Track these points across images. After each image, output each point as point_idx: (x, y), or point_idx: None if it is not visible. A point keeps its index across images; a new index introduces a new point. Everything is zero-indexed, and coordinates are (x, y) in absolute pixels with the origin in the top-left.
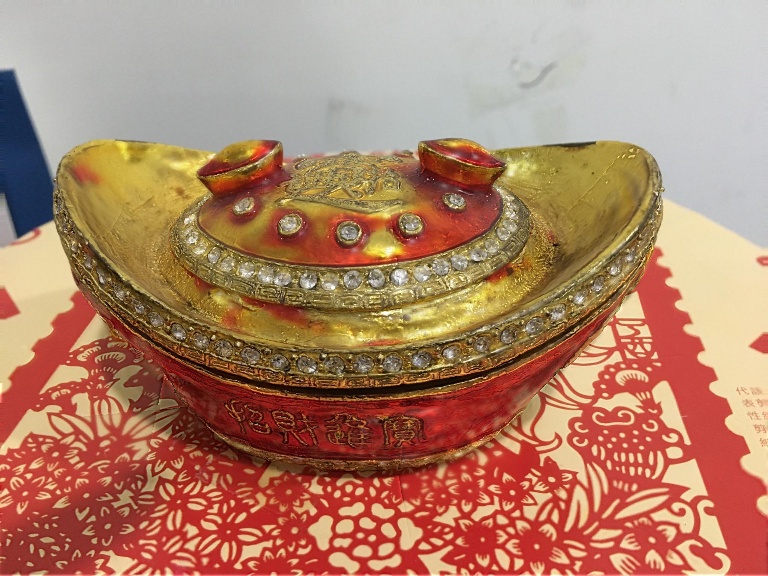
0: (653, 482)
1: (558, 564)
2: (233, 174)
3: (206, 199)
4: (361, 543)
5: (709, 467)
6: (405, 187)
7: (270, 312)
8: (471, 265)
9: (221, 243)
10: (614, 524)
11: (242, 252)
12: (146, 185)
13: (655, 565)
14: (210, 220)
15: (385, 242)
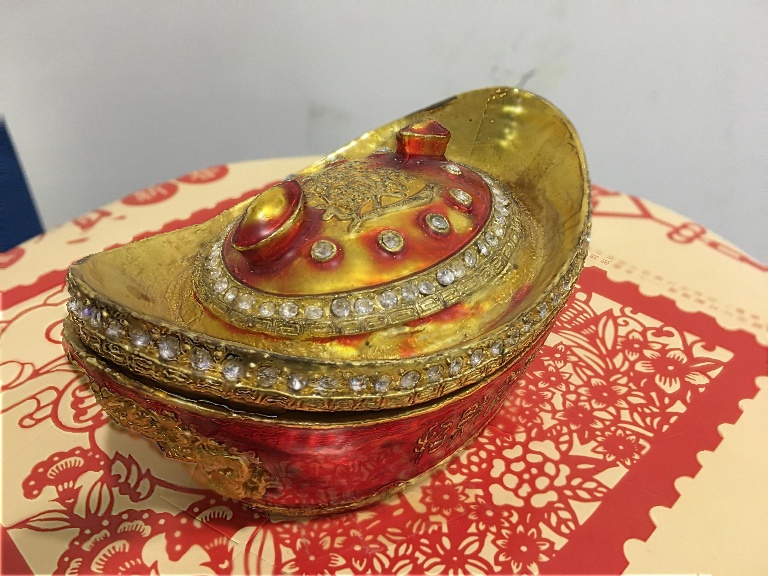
0: (595, 318)
1: (625, 393)
2: (287, 227)
3: (227, 278)
4: (534, 479)
5: (604, 291)
6: (414, 175)
7: (440, 321)
8: (507, 209)
9: (338, 293)
10: (614, 352)
11: (371, 288)
12: (129, 304)
13: (655, 356)
14: (292, 284)
15: (461, 218)
